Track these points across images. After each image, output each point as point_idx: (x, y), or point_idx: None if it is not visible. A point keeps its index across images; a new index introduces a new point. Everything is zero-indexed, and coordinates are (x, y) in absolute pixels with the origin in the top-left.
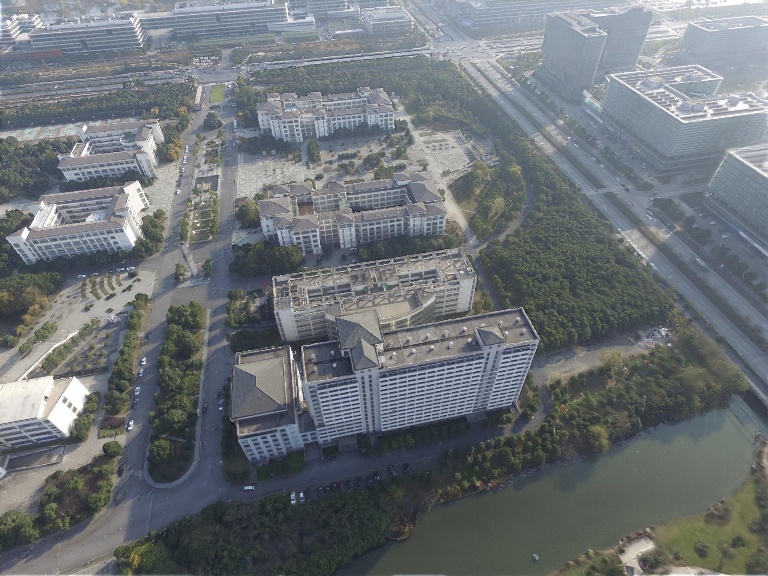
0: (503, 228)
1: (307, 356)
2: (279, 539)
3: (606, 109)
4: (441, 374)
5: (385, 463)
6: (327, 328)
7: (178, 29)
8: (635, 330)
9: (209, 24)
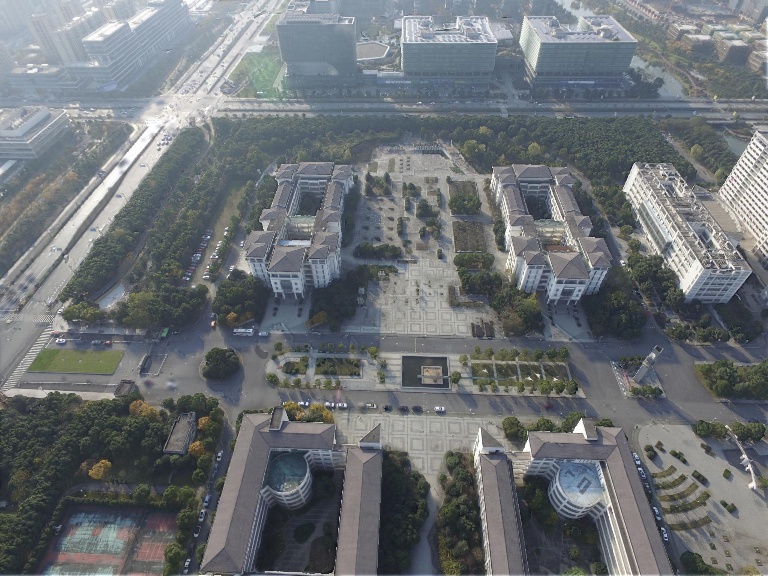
0: None
1: None
2: None
3: (411, 70)
4: None
5: None
6: None
7: None
8: None
9: None
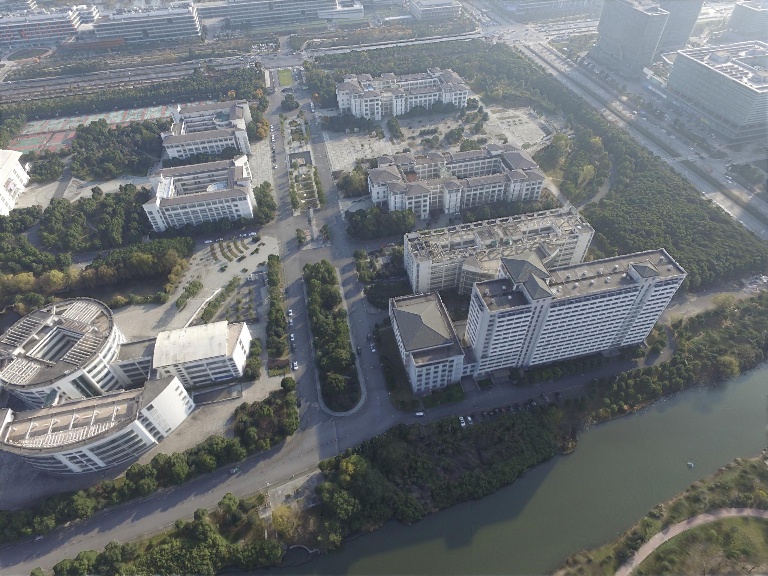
0: (594, 193)
1: (481, 291)
2: (460, 454)
3: (671, 84)
4: (600, 306)
5: (537, 392)
6: (460, 279)
7: (232, 18)
8: (738, 278)
9: (262, 12)
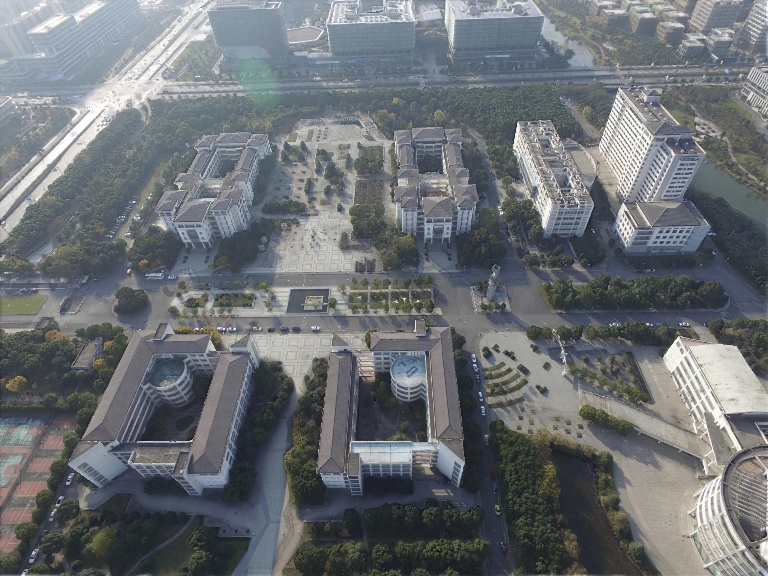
0: None
1: None
2: None
3: (338, 50)
4: None
5: None
6: None
7: None
8: None
9: None
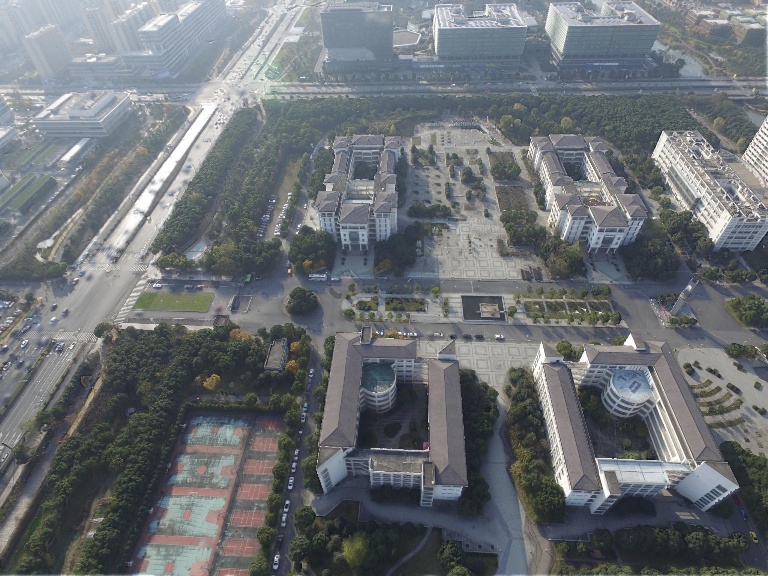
0: None
1: None
2: None
3: (444, 55)
4: None
5: None
6: None
7: None
8: None
9: None
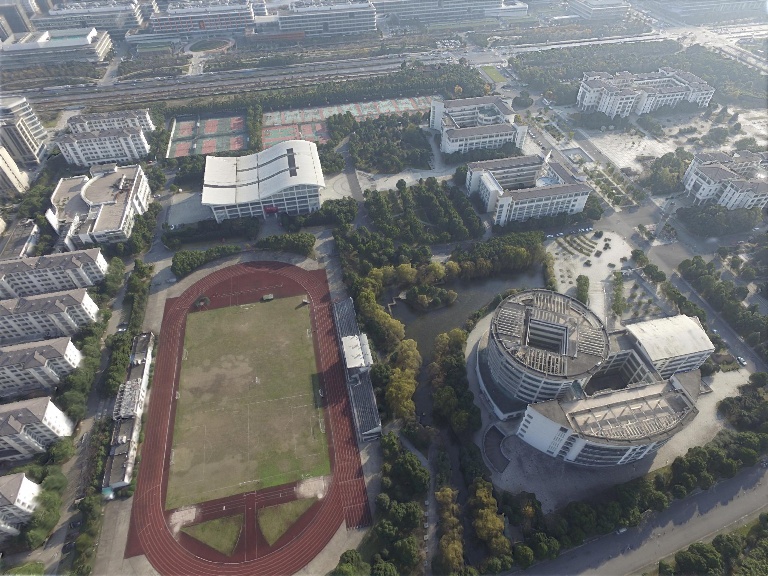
0: None
1: None
2: None
3: None
4: None
5: None
6: None
7: (402, 13)
8: None
9: (431, 9)
